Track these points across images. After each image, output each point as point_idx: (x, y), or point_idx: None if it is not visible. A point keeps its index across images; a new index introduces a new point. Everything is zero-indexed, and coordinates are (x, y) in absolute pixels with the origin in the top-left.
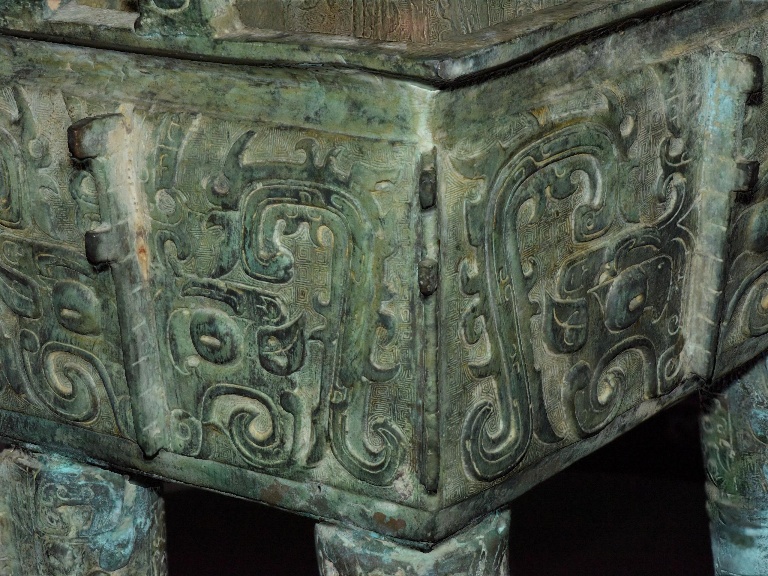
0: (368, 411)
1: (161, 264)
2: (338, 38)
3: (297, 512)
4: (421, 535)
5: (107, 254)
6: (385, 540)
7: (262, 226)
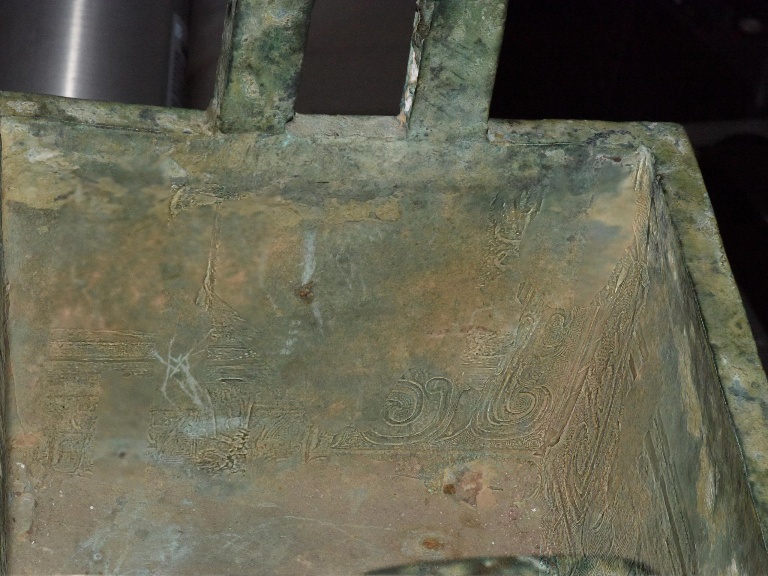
0: None
1: None
2: (88, 113)
3: None
4: None
5: None
6: None
7: None
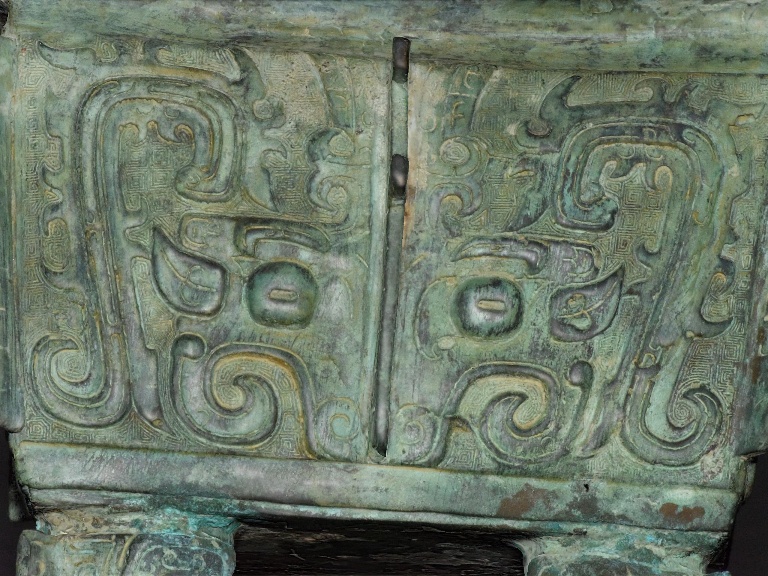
0: (681, 376)
1: (428, 227)
2: None
3: (540, 528)
4: (723, 522)
5: (406, 186)
6: (659, 546)
7: (587, 169)
